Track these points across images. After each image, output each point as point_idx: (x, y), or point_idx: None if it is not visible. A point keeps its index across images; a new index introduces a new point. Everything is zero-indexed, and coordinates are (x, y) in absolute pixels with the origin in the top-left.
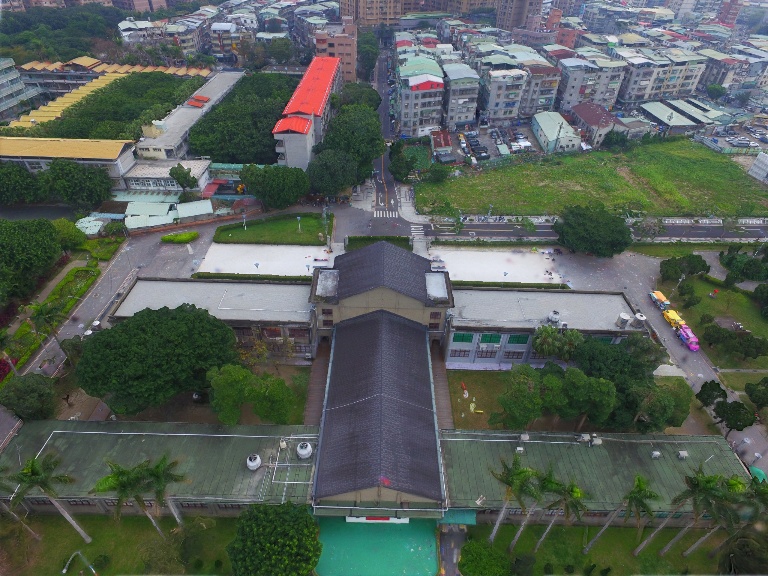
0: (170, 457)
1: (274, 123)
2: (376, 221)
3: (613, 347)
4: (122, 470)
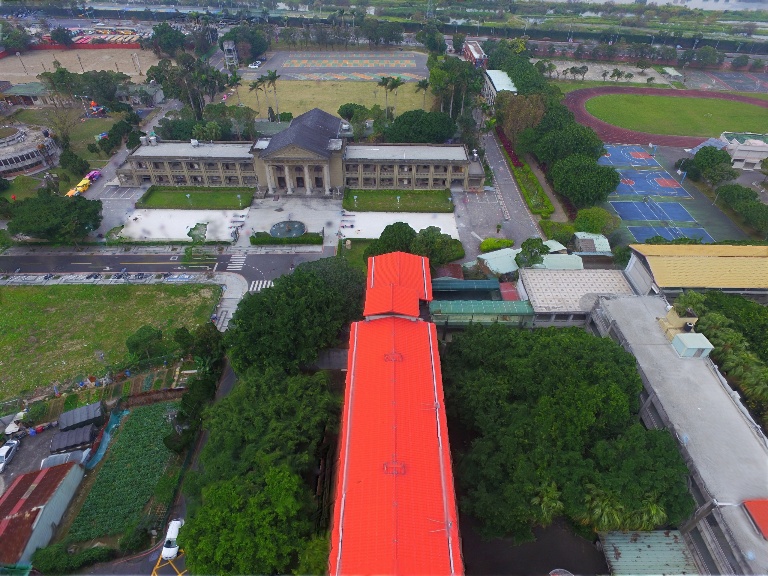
0: None
1: (467, 383)
2: (283, 273)
3: None
4: None
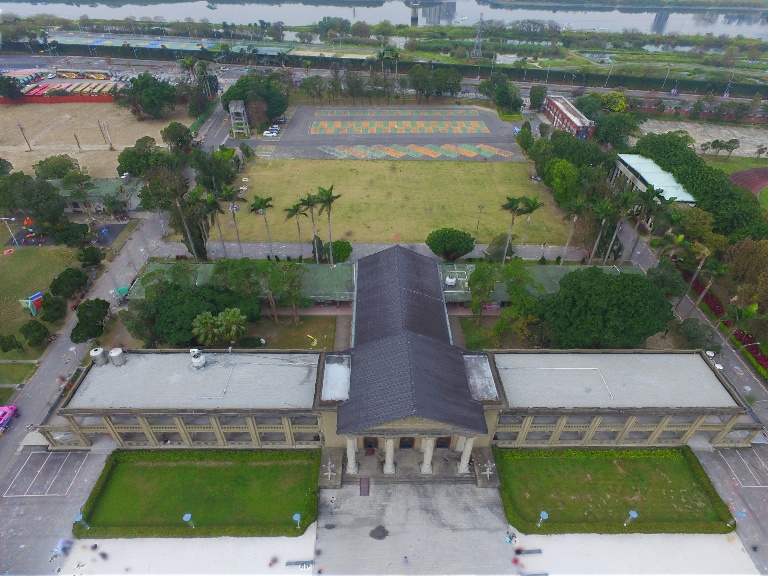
0: (540, 282)
1: None
2: None
3: (169, 318)
4: (534, 205)
